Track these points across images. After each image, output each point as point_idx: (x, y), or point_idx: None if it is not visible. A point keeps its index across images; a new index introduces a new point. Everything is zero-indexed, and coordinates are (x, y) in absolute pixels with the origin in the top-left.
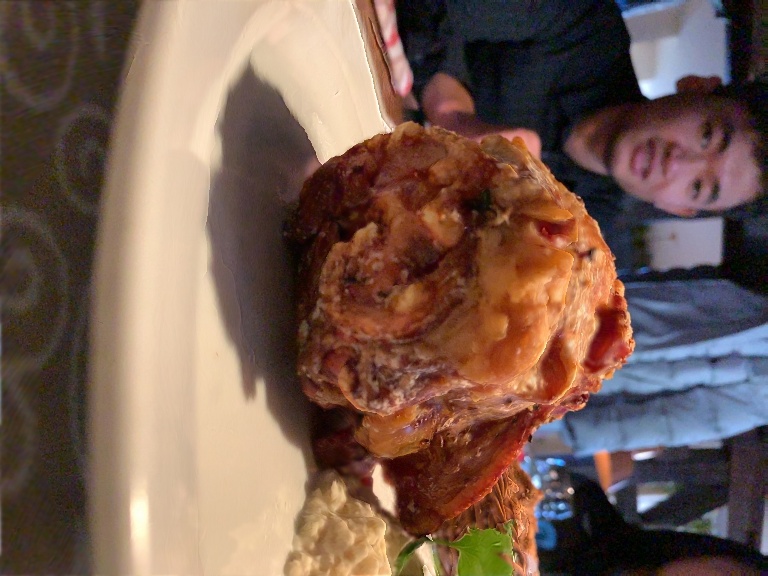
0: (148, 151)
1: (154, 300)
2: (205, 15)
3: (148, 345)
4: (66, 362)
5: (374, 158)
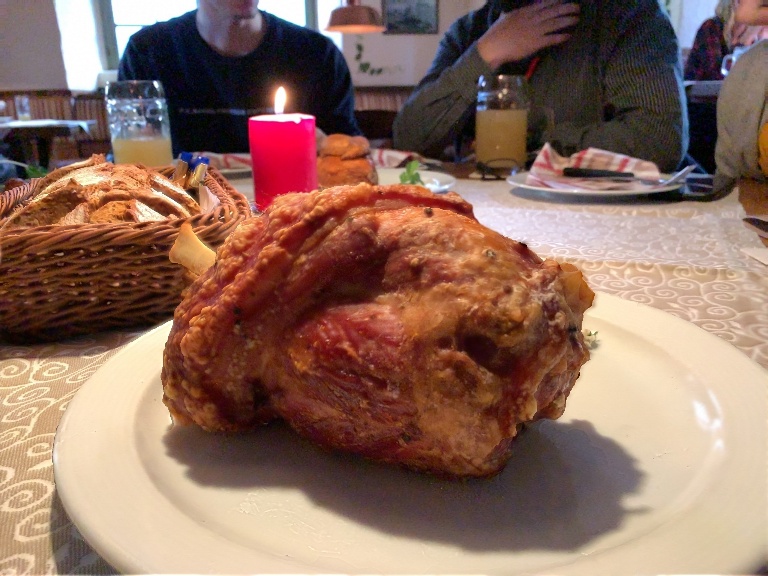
0: None
1: None
2: None
3: None
4: None
5: None
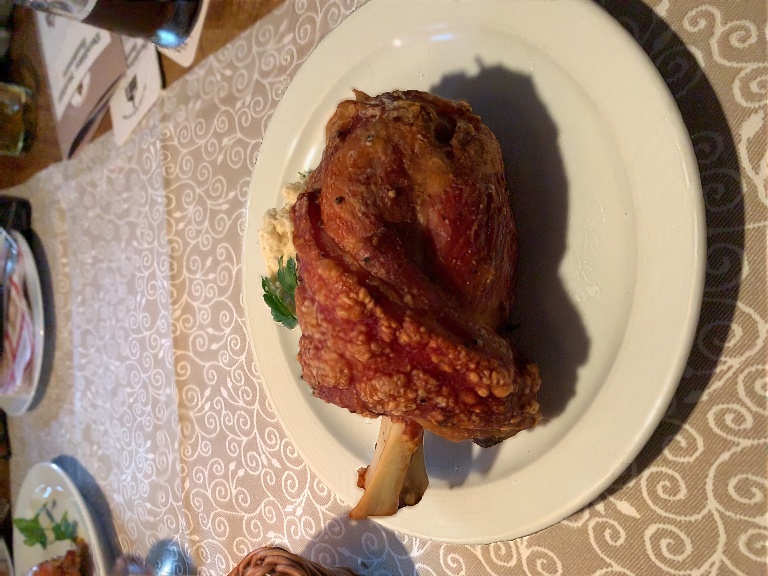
0: None
1: (372, 0)
2: None
3: None
4: None
5: None
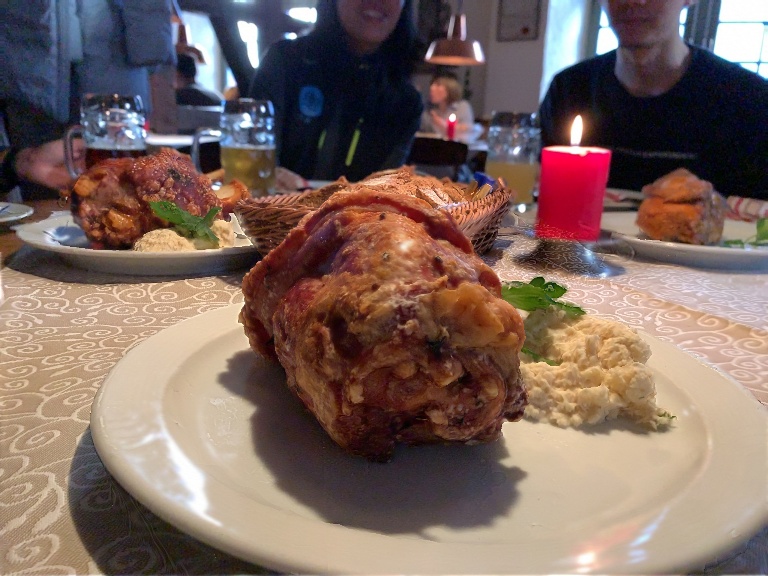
0: (647, 571)
1: (689, 550)
2: (544, 568)
3: (701, 547)
4: (709, 573)
5: (356, 410)
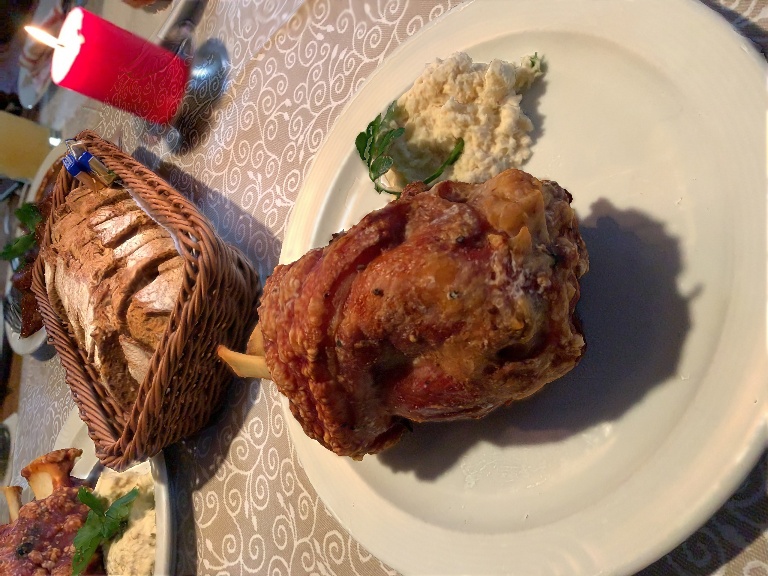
0: None
1: None
2: None
3: None
4: None
5: None
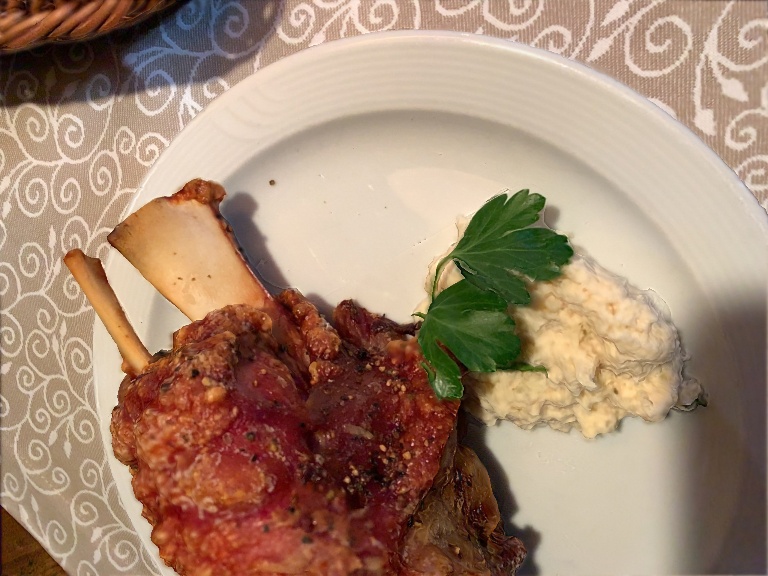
0: None
1: None
2: None
3: None
4: None
5: None
